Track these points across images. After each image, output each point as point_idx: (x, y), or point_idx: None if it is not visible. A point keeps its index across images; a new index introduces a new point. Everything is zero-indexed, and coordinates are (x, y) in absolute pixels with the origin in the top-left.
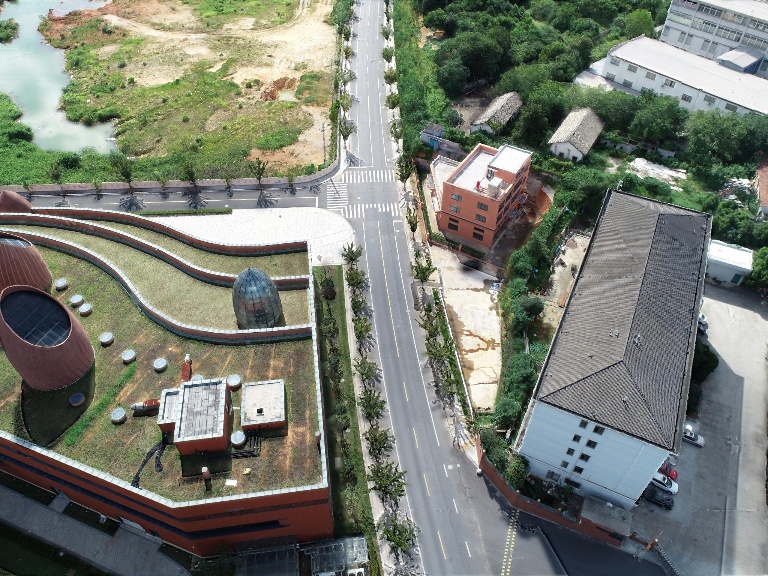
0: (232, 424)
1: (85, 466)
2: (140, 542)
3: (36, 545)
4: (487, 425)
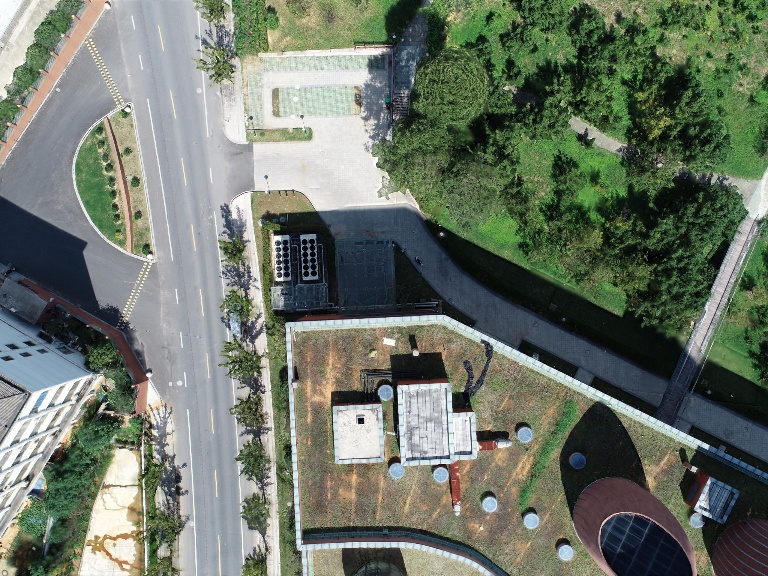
0: (395, 412)
1: (546, 373)
2: (495, 331)
3: (593, 335)
4: (127, 426)
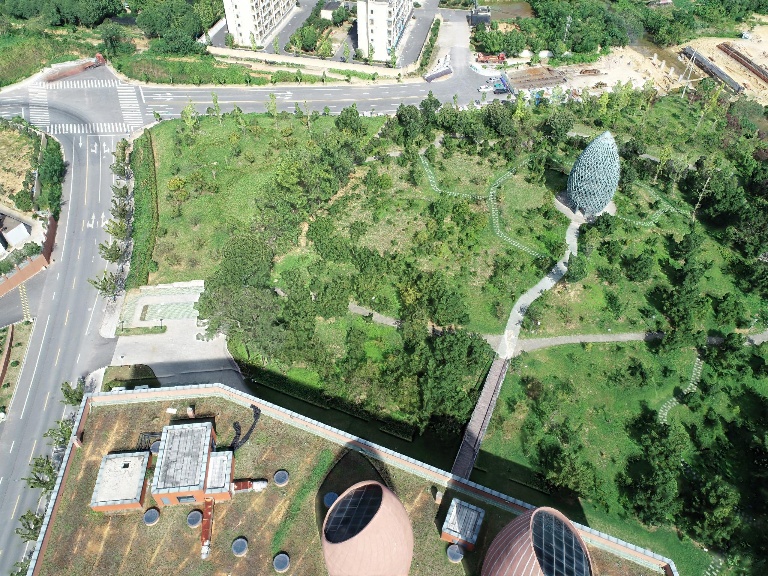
0: None
1: None
2: None
3: None
4: None
